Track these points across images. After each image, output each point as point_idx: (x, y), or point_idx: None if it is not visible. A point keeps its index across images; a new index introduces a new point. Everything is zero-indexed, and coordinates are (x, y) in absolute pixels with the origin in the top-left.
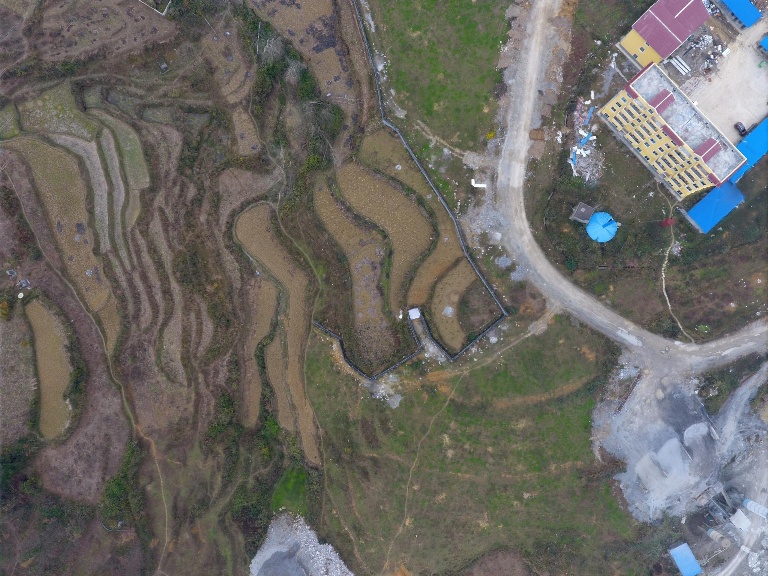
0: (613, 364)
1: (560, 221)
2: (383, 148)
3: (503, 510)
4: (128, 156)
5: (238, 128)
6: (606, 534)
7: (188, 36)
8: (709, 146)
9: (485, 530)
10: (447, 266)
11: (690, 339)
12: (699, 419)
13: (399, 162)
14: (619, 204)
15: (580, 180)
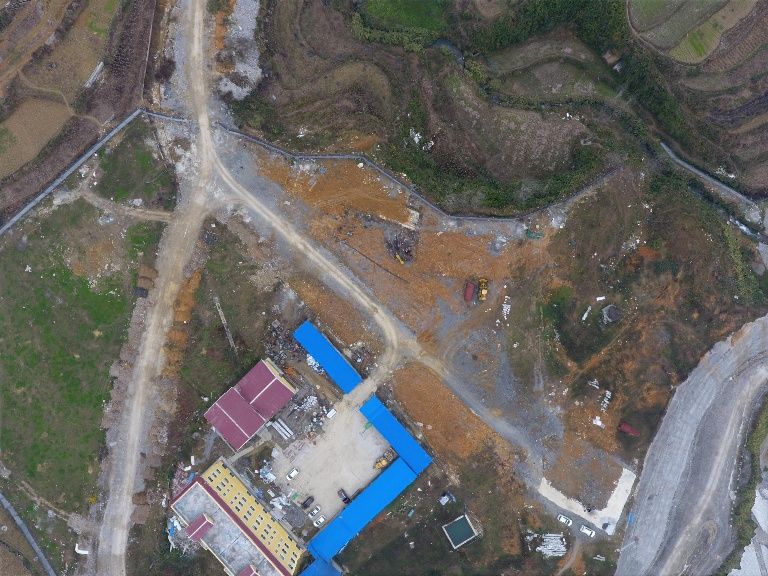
0: None
1: None
2: None
3: None
4: None
5: None
6: None
7: None
8: None
9: None
10: None
11: None
12: None
13: (5, 523)
14: None
15: (178, 552)
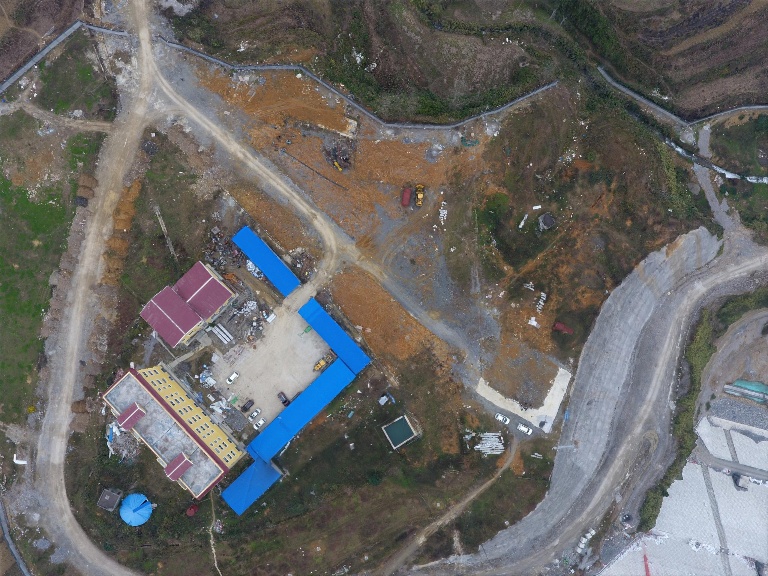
0: None
1: (92, 504)
2: None
3: None
4: None
5: None
6: None
7: None
8: (177, 463)
9: None
10: None
11: None
12: None
13: None
14: (157, 483)
15: (117, 458)
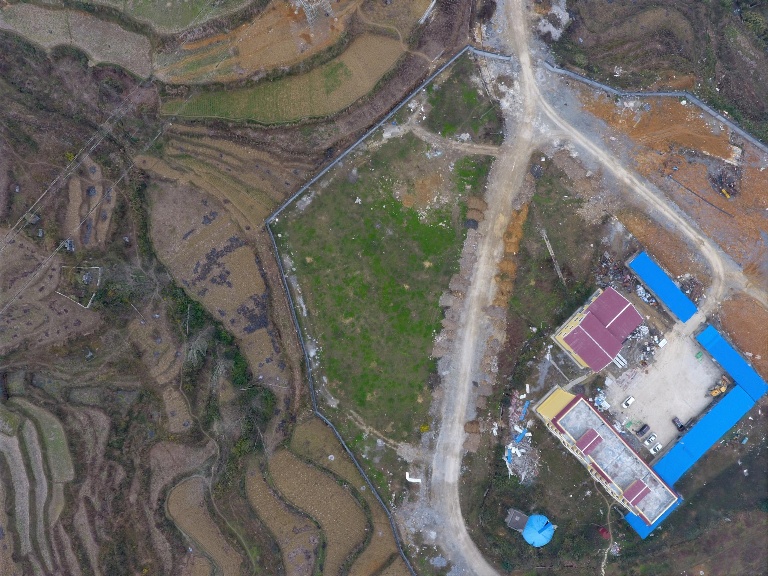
0: None
1: (495, 524)
2: (315, 437)
3: None
4: (52, 447)
5: (169, 406)
6: None
7: (114, 323)
8: (638, 490)
9: None
10: (382, 562)
11: None
12: None
13: (332, 452)
14: (556, 504)
15: (516, 479)
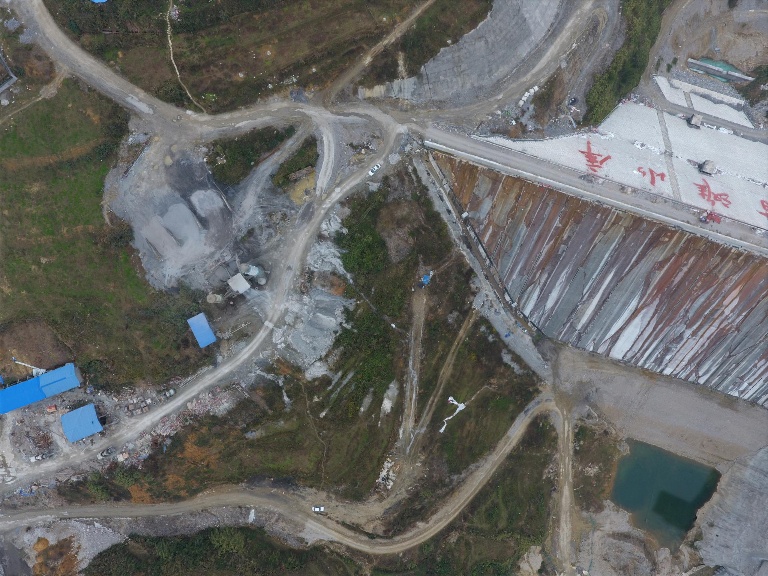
0: (122, 129)
1: None
2: None
3: (22, 274)
4: None
5: None
6: (124, 301)
7: None
8: None
9: (9, 296)
10: None
11: (201, 109)
12: (206, 186)
13: None
14: None
15: None
